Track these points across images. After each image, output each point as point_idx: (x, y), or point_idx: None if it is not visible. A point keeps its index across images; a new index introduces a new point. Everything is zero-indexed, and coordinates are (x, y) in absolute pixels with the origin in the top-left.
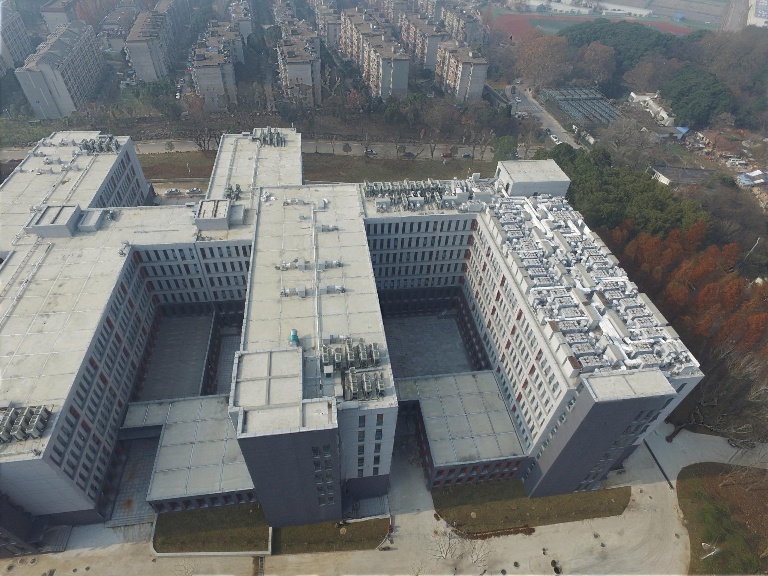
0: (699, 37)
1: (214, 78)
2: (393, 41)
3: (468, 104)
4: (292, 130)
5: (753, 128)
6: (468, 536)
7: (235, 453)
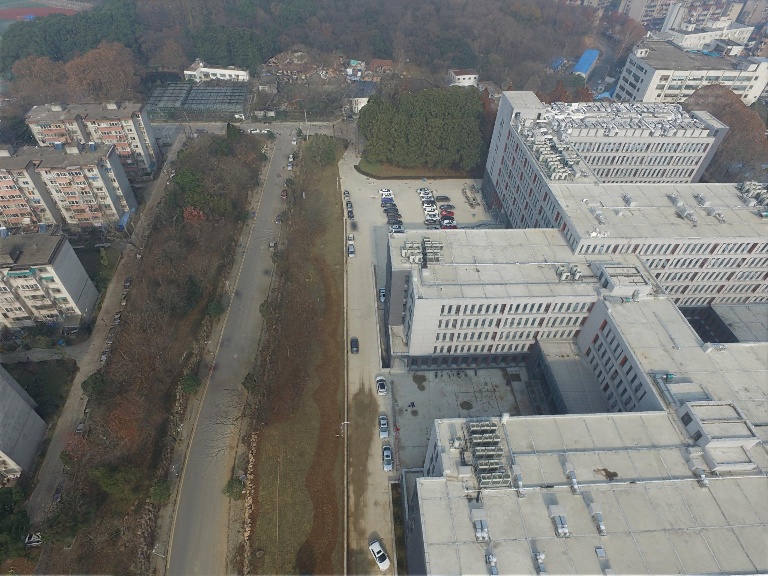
0: (125, 6)
1: (0, 399)
2: (22, 148)
3: (194, 151)
4: (394, 237)
5: (281, 51)
6: None
7: (766, 316)
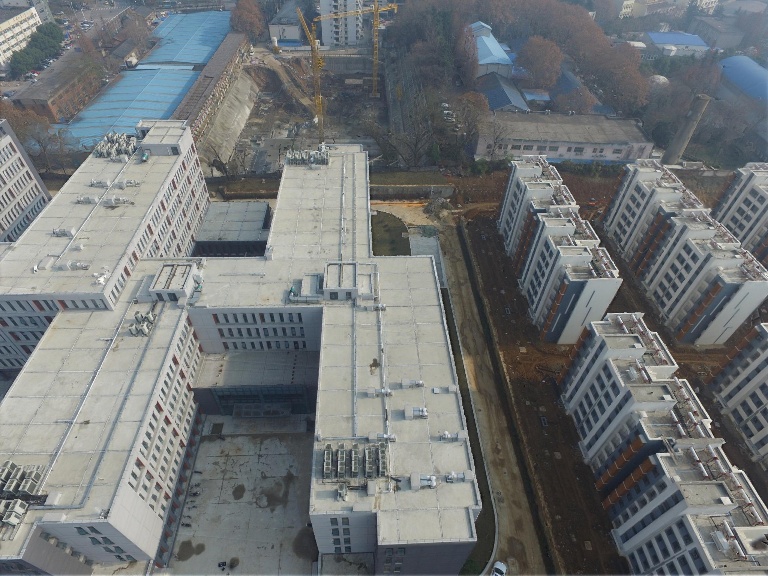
0: None
1: None
2: None
3: None
4: None
5: None
6: None
7: (220, 215)
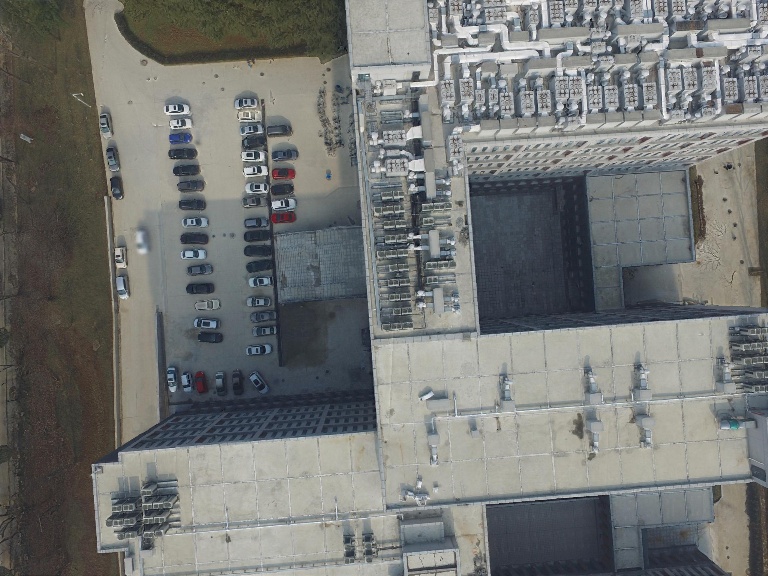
0: None
1: None
2: None
3: None
4: (101, 472)
5: None
6: (703, 236)
7: None
